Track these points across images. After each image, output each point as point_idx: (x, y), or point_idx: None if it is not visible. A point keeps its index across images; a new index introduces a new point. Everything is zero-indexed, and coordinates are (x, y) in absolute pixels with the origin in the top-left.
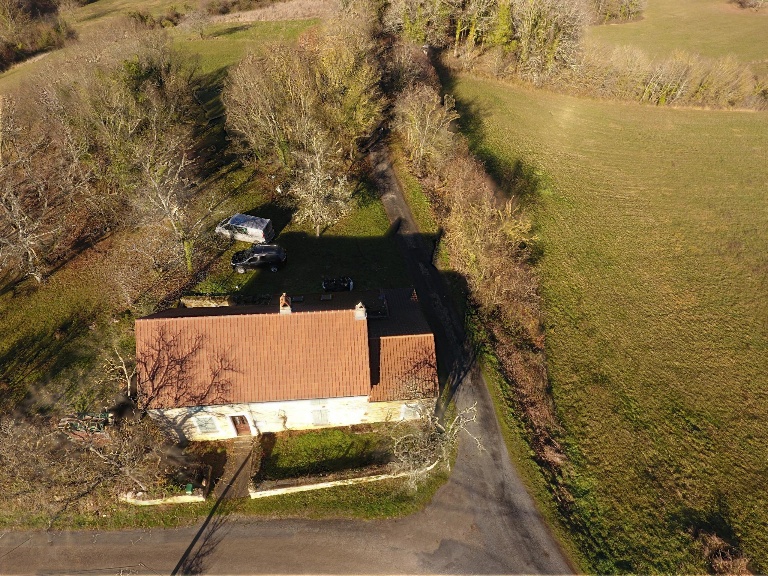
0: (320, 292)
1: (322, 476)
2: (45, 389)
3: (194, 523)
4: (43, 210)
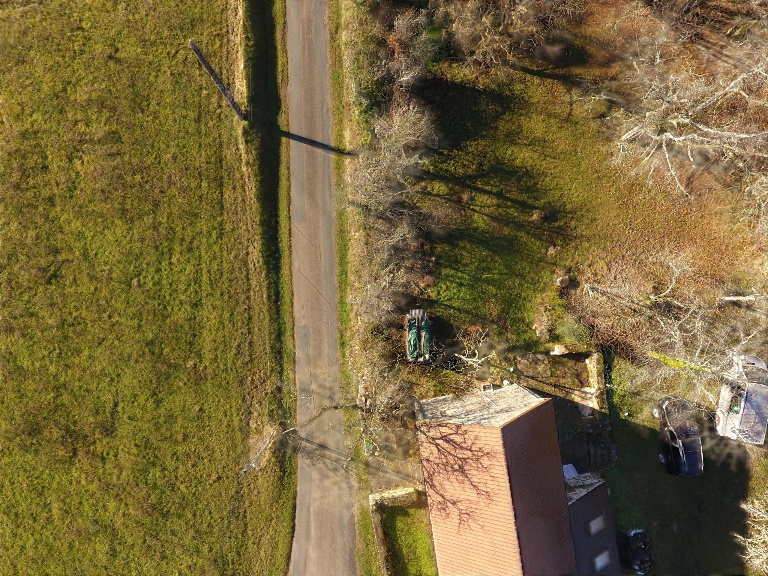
0: (625, 527)
1: (387, 568)
2: (464, 247)
3: (348, 447)
4: (733, 133)
